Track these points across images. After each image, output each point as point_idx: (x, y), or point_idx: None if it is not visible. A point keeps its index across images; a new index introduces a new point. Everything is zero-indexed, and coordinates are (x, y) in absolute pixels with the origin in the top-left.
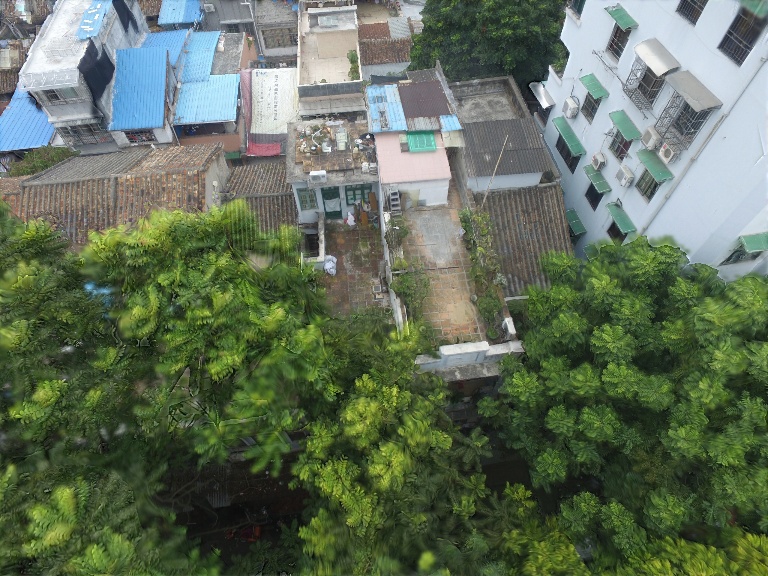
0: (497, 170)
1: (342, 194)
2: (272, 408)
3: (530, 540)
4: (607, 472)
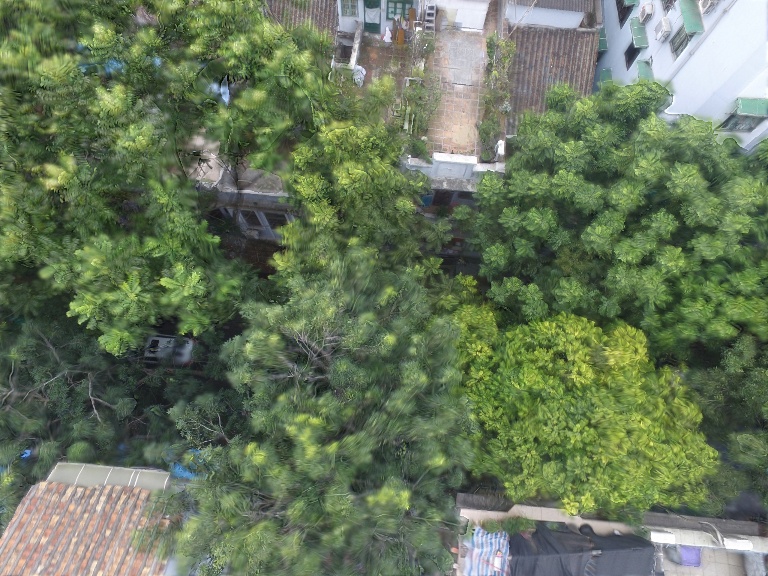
0: (538, 1)
1: (383, 4)
2: (284, 186)
3: (461, 303)
4: (540, 273)
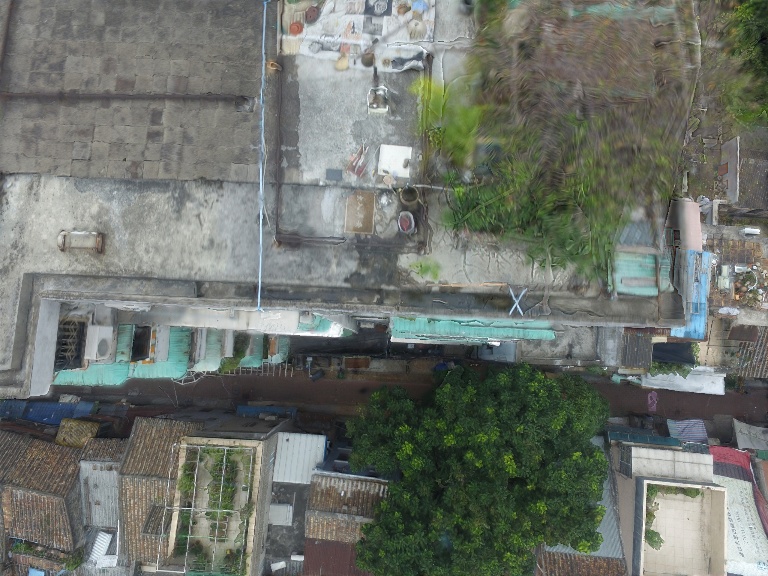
0: None
1: None
2: None
3: None
4: None
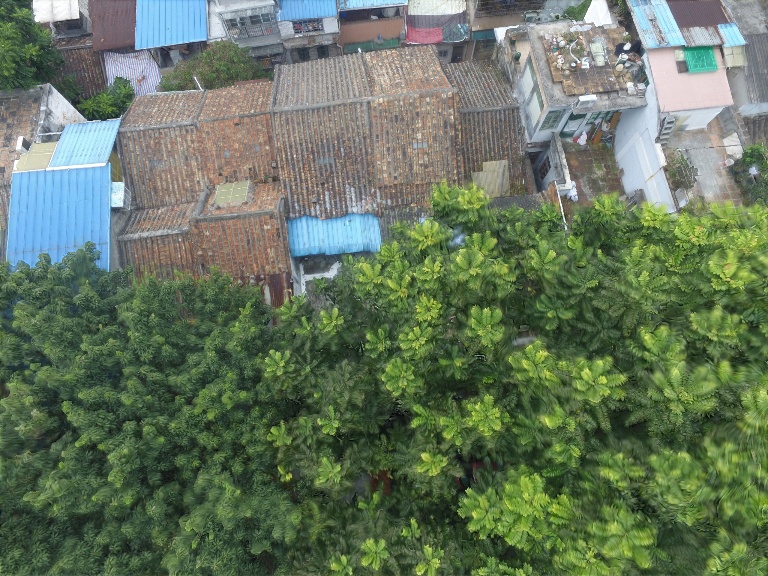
0: None
1: (589, 114)
2: None
3: None
4: None
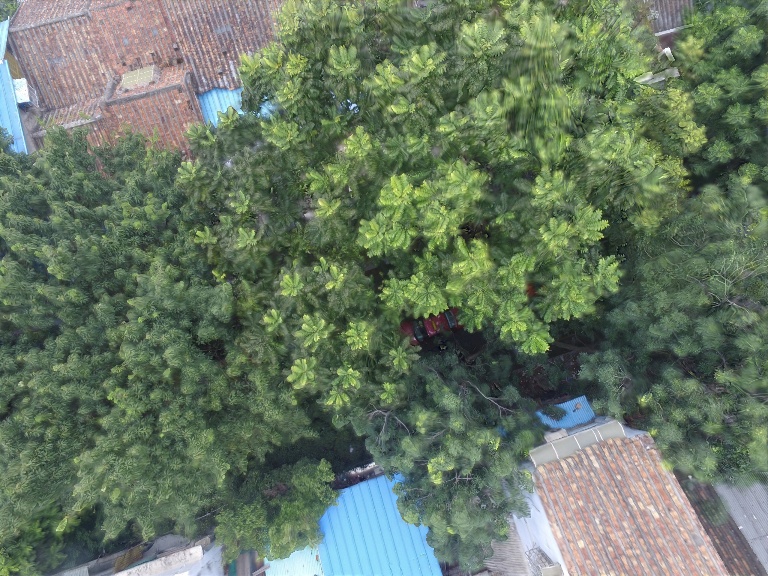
0: None
1: None
2: None
3: None
4: (753, 152)
